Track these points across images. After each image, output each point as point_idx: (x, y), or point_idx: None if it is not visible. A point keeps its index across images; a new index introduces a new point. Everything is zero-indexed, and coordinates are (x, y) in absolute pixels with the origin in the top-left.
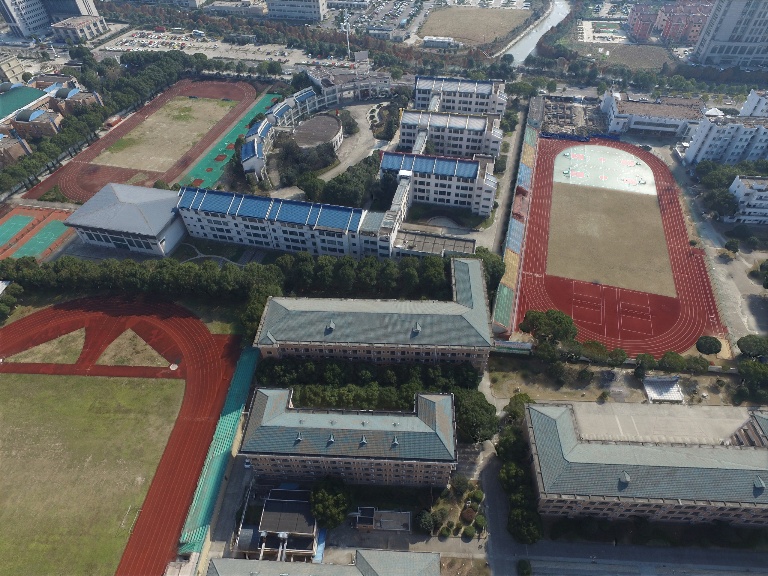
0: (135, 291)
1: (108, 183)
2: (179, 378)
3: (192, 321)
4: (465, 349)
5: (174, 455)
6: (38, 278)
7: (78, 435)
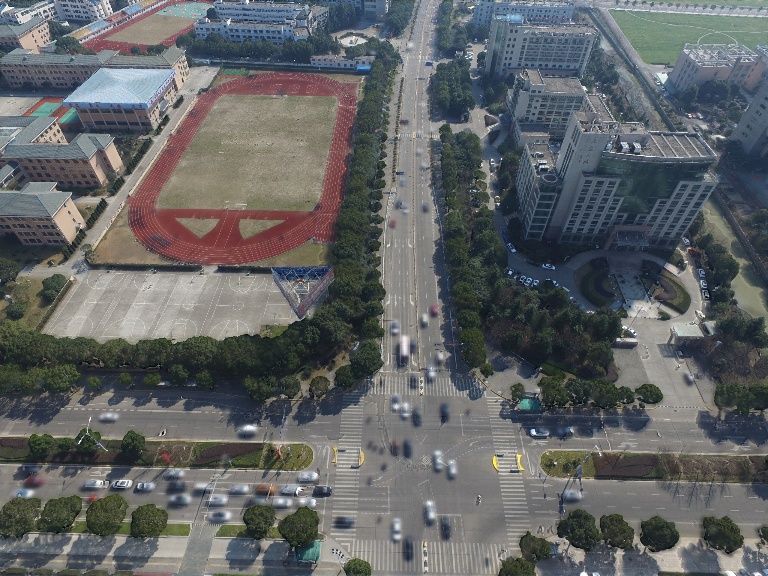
0: None
1: None
2: None
3: None
4: (8, 39)
5: None
6: None
7: None
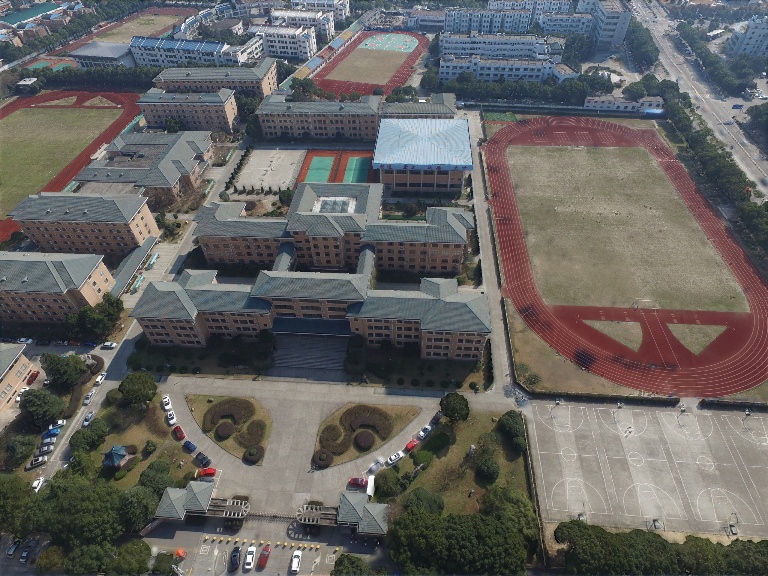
0: (103, 80)
1: (94, 41)
2: (121, 109)
3: (132, 94)
4: (250, 83)
5: (114, 126)
6: (54, 75)
7: (71, 122)
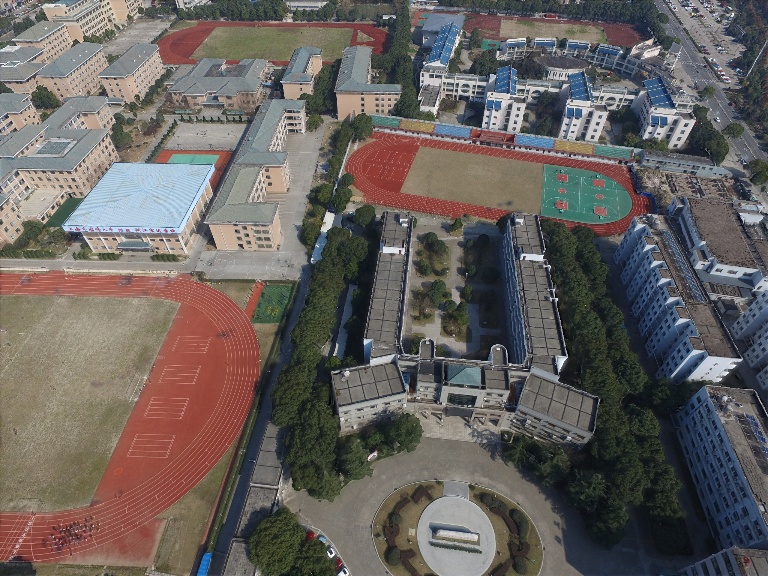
0: None
1: None
2: None
3: None
4: None
5: None
6: (396, 20)
7: None
